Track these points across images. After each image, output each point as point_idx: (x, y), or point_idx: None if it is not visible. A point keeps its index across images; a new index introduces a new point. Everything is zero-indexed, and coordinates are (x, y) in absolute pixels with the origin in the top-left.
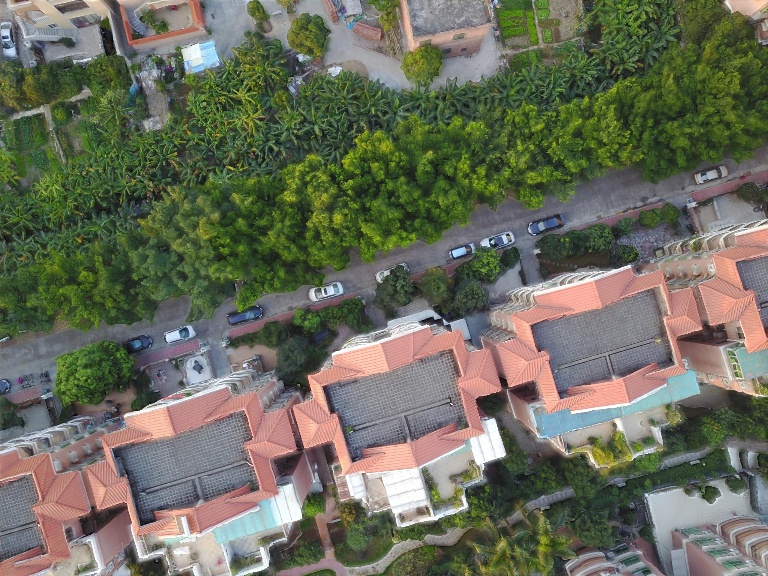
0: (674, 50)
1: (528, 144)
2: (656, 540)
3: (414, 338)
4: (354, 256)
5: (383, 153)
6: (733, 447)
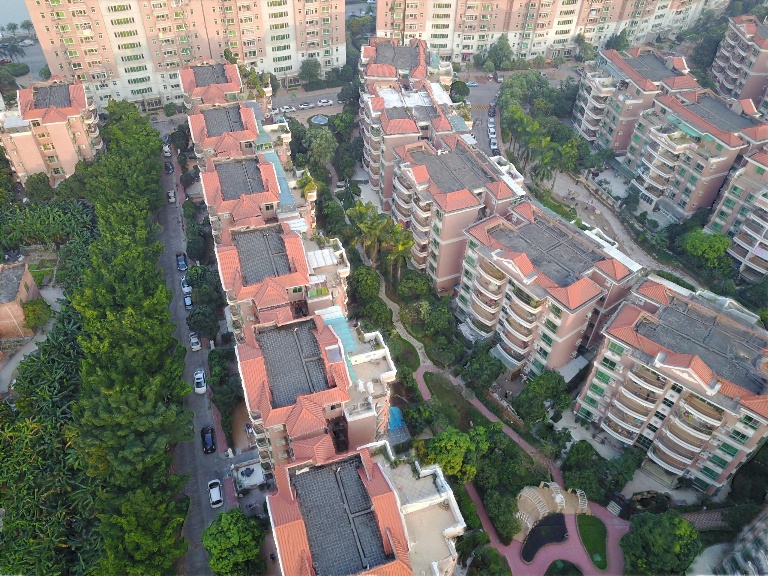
0: (86, 188)
1: None
2: None
3: None
4: None
5: (93, 298)
6: (334, 190)
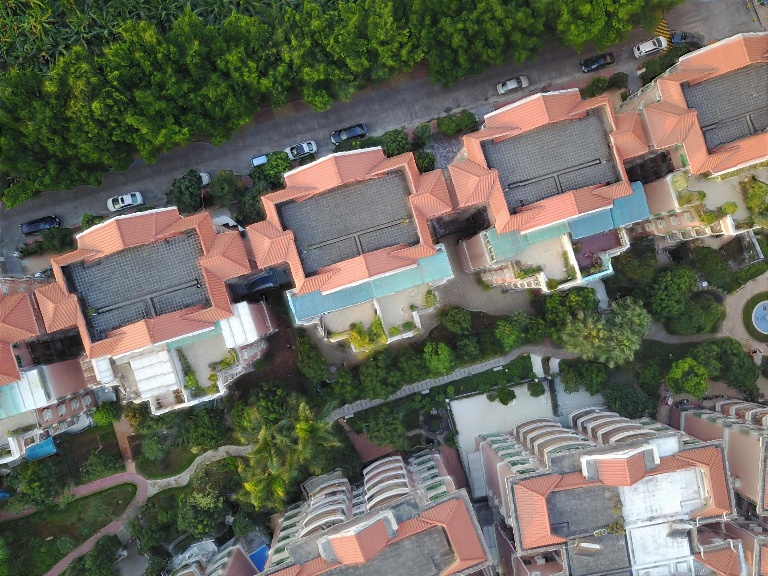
0: None
1: (305, 40)
2: (458, 445)
3: (157, 218)
4: (155, 166)
5: (152, 45)
6: (535, 353)
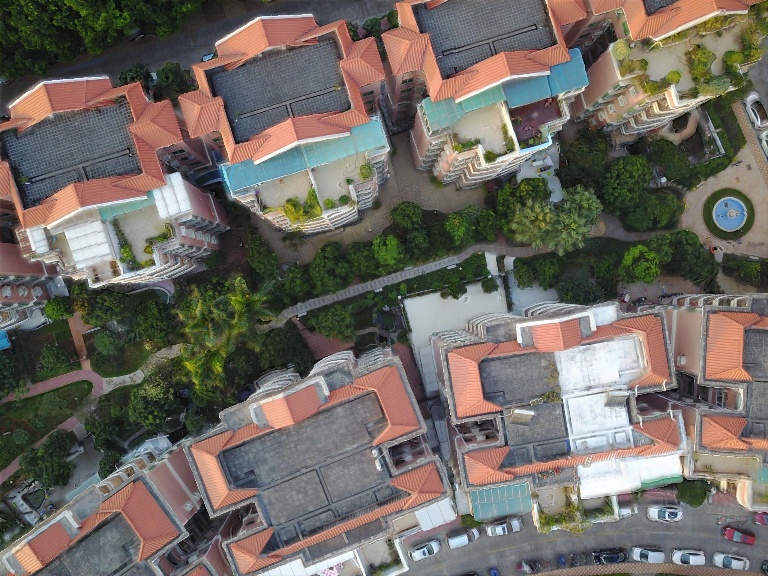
0: None
1: None
2: (411, 342)
3: (88, 86)
4: (107, 67)
5: None
6: (490, 252)
